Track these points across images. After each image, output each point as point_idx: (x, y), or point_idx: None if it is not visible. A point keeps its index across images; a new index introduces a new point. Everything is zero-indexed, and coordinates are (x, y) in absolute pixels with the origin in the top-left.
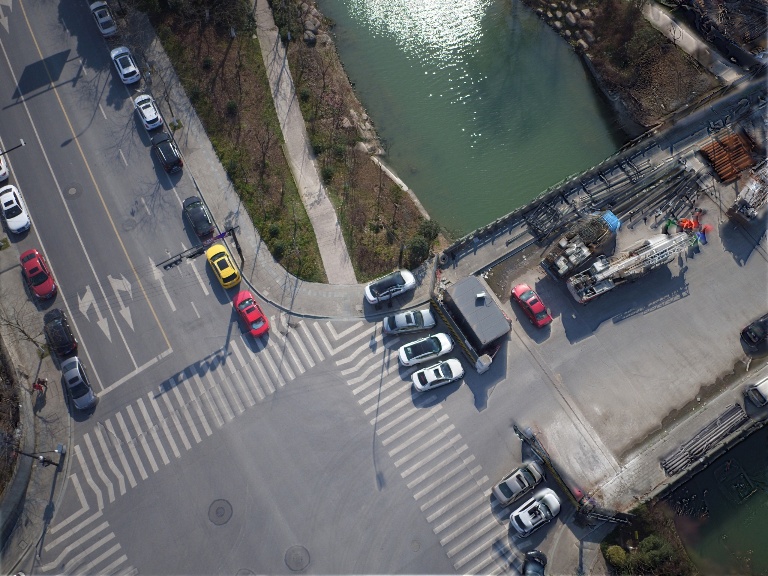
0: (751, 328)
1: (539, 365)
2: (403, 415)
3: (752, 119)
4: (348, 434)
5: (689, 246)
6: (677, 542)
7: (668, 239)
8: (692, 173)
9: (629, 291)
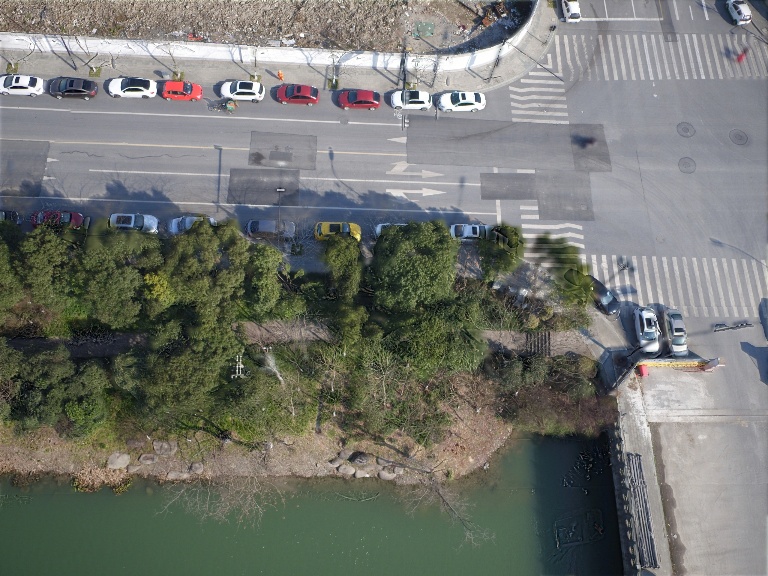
0: None
1: (762, 415)
2: (760, 285)
3: None
4: (761, 240)
5: None
6: (571, 428)
7: None
8: None
9: None
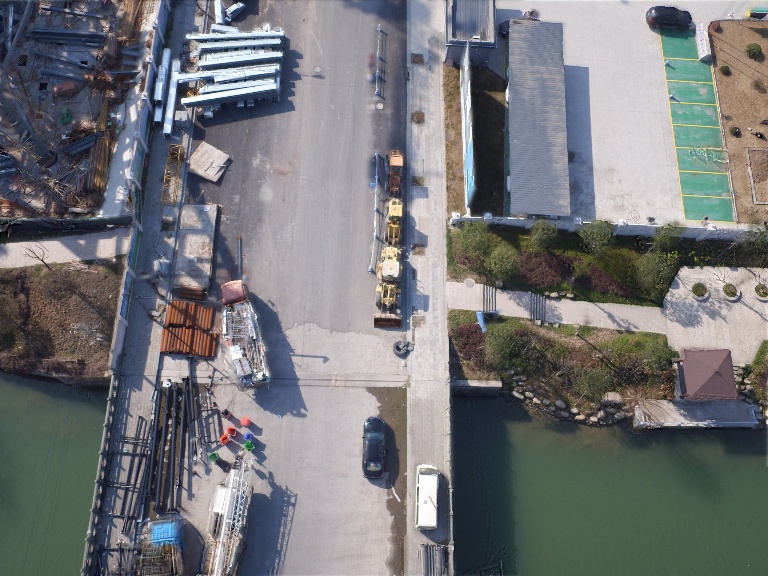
0: (366, 461)
1: None
2: None
3: (180, 268)
4: None
5: (252, 452)
6: None
7: (227, 495)
8: (186, 382)
9: (251, 558)
